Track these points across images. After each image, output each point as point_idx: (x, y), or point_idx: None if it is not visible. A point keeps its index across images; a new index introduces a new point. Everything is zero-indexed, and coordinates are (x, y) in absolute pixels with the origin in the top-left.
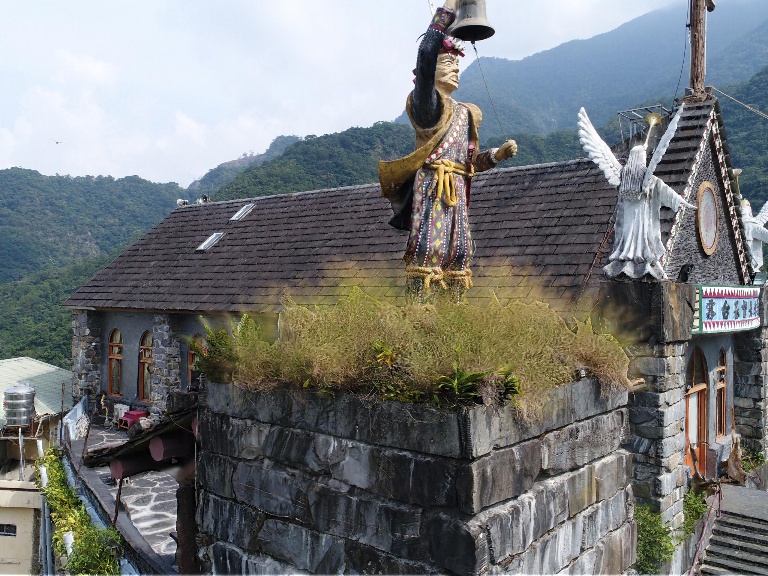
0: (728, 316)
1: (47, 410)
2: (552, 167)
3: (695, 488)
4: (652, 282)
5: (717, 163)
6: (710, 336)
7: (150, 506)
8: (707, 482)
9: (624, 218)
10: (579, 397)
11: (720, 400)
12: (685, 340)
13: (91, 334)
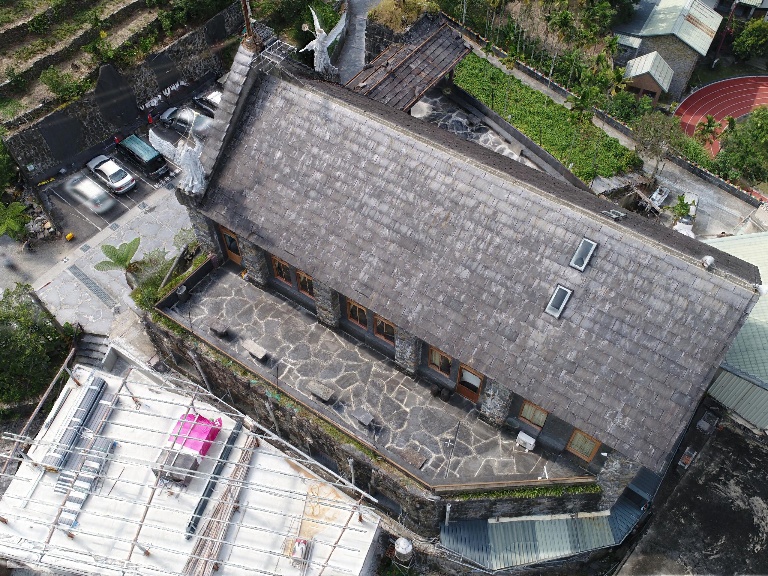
0: None
1: None
2: None
3: None
4: None
5: None
6: None
7: None
8: None
9: None
10: None
11: None
12: None
13: None
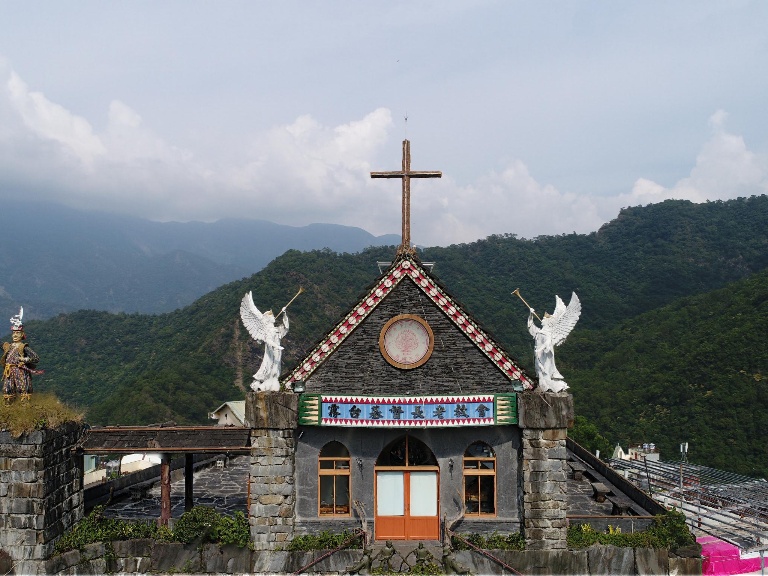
0: (360, 416)
1: None
2: None
3: None
4: None
5: None
6: None
7: None
8: None
9: None
10: (3, 437)
11: None
12: (277, 428)
13: None
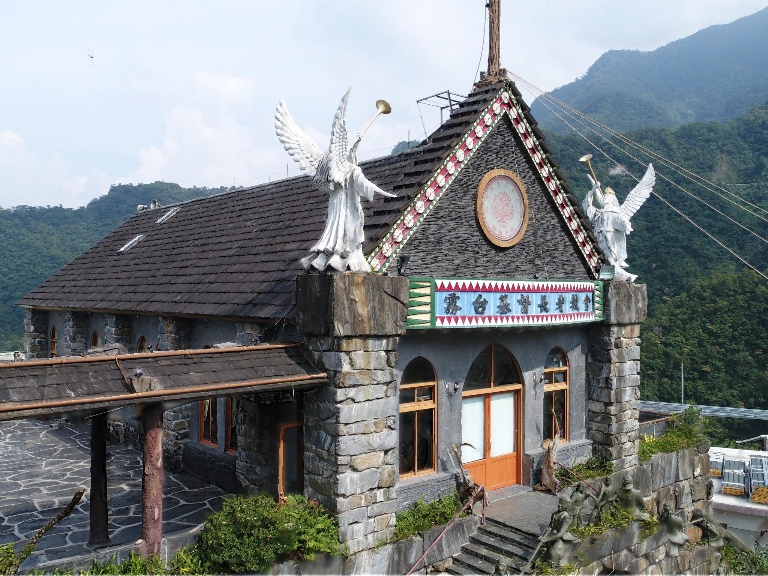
0: (486, 311)
1: None
2: (381, 160)
3: (463, 493)
4: (330, 274)
5: (524, 149)
6: (520, 333)
7: None
8: (468, 487)
9: (328, 209)
10: None
11: (563, 403)
12: (382, 334)
13: (36, 331)
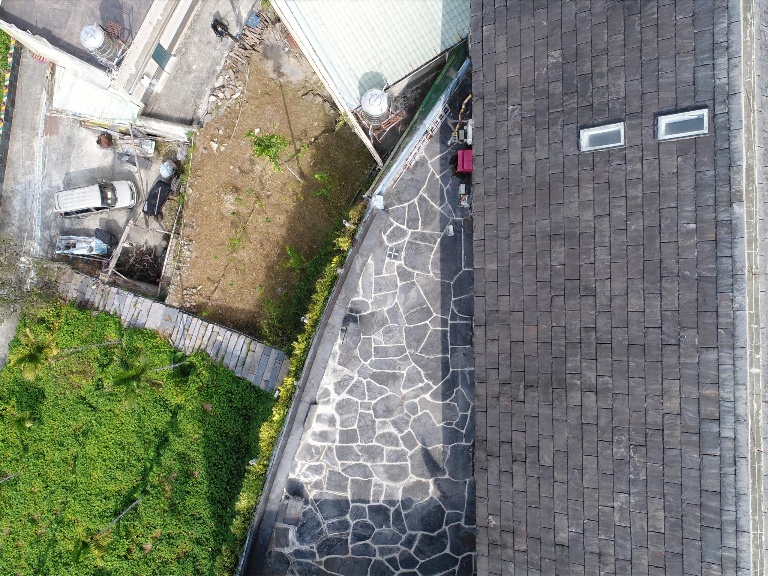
0: None
1: (435, 42)
2: None
3: None
4: None
5: None
6: None
7: (340, 399)
8: None
9: None
10: None
11: None
12: None
13: None
